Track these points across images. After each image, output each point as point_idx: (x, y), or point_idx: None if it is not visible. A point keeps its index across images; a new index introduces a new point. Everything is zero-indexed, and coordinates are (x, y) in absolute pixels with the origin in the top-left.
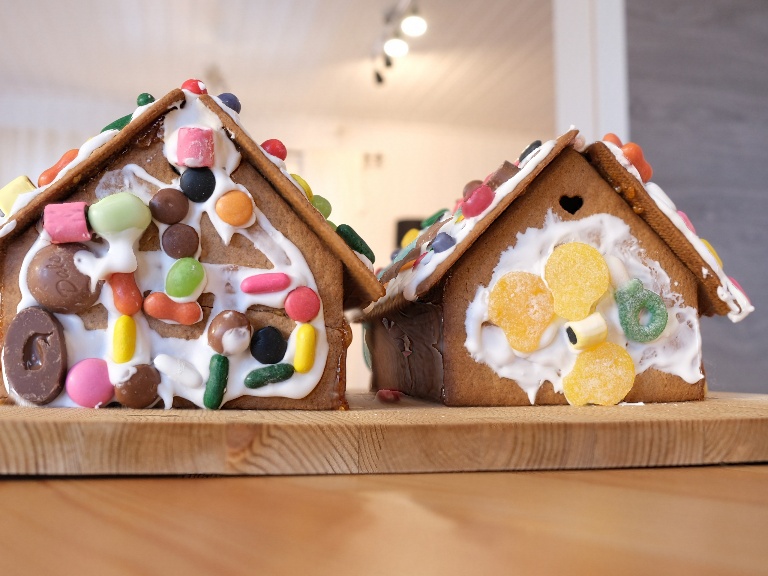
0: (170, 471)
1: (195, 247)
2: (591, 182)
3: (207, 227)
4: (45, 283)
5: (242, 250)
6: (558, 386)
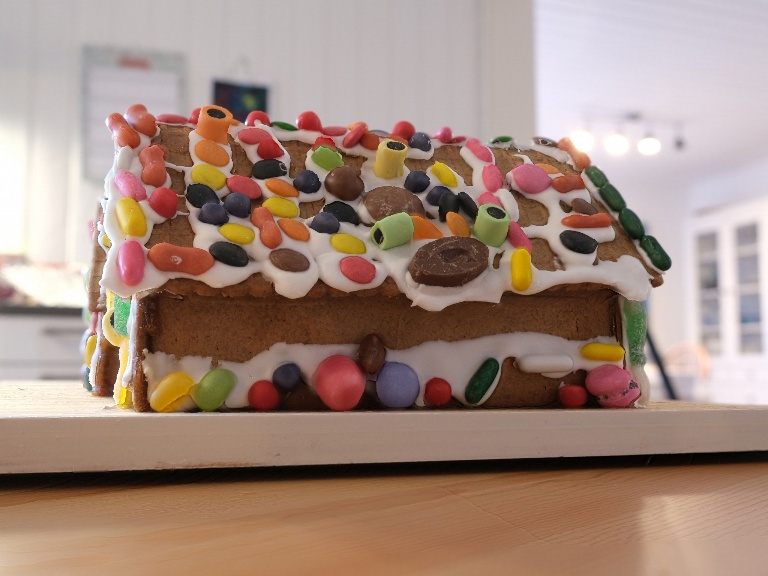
0: None
1: None
2: None
3: None
4: None
5: None
6: None
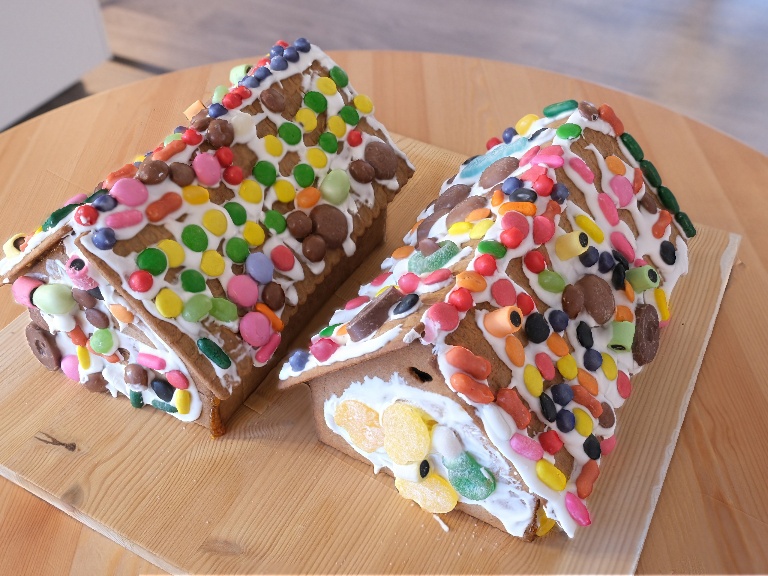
0: (45, 500)
1: (105, 325)
2: None
3: None
4: (32, 318)
5: (137, 332)
6: None
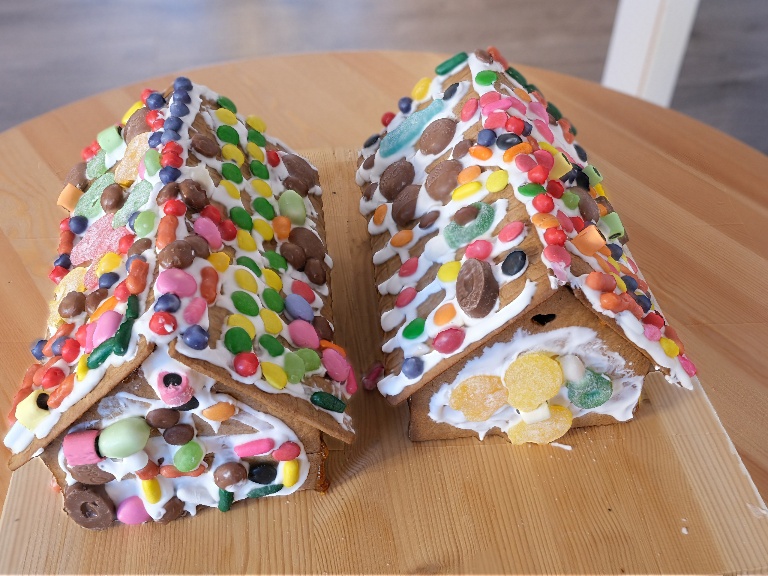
0: None
1: None
2: (567, 305)
3: (198, 418)
4: (82, 479)
5: (231, 426)
6: (505, 430)
